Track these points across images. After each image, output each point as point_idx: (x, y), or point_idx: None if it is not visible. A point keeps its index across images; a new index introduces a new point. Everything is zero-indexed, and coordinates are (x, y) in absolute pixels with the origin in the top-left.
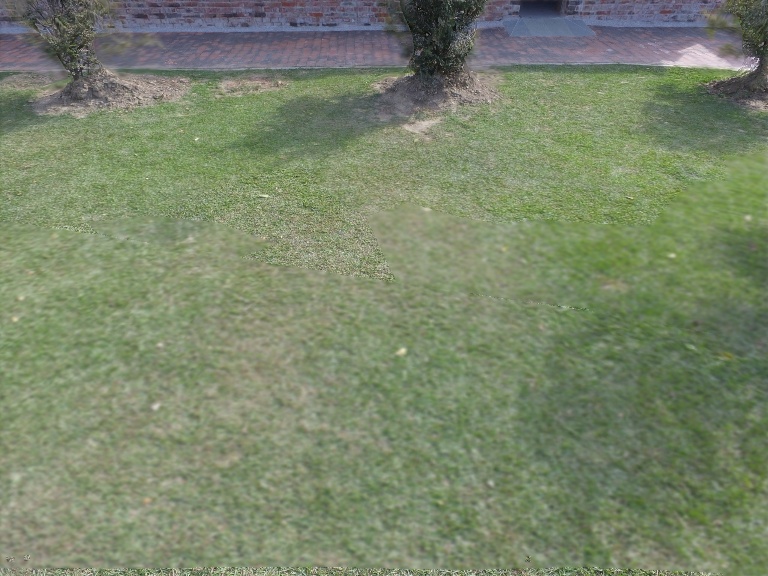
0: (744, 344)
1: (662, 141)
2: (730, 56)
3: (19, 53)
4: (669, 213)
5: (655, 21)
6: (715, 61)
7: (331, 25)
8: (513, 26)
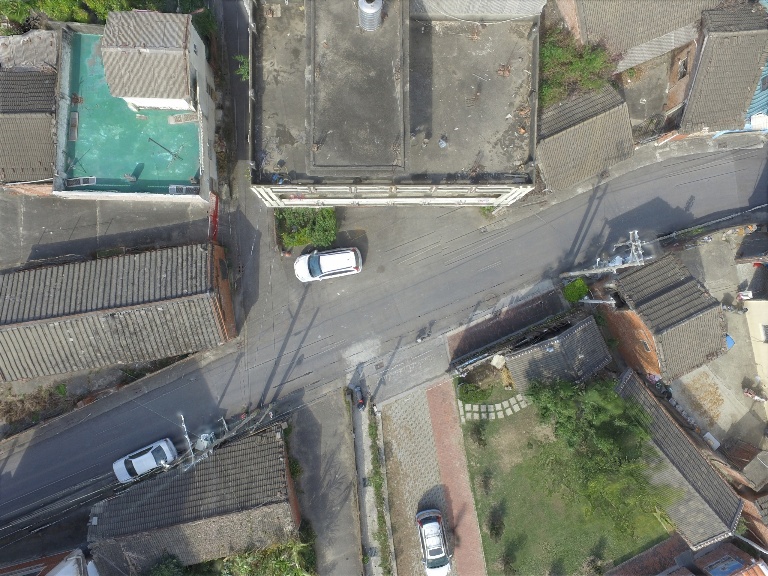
0: (516, 547)
1: None
2: None
3: (625, 575)
4: (520, 563)
5: None
6: None
7: None
8: None
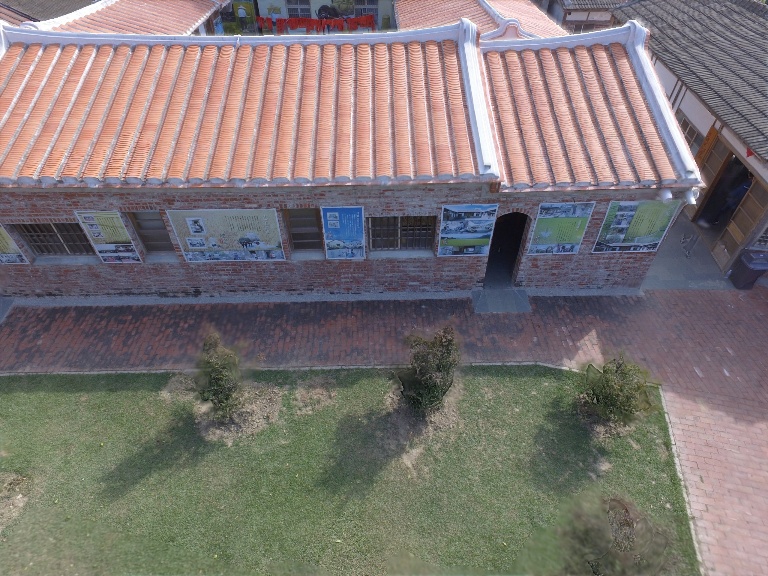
0: None
1: (535, 480)
2: (608, 351)
3: (165, 340)
4: (519, 559)
5: (575, 288)
6: (596, 361)
7: (357, 293)
8: (478, 300)
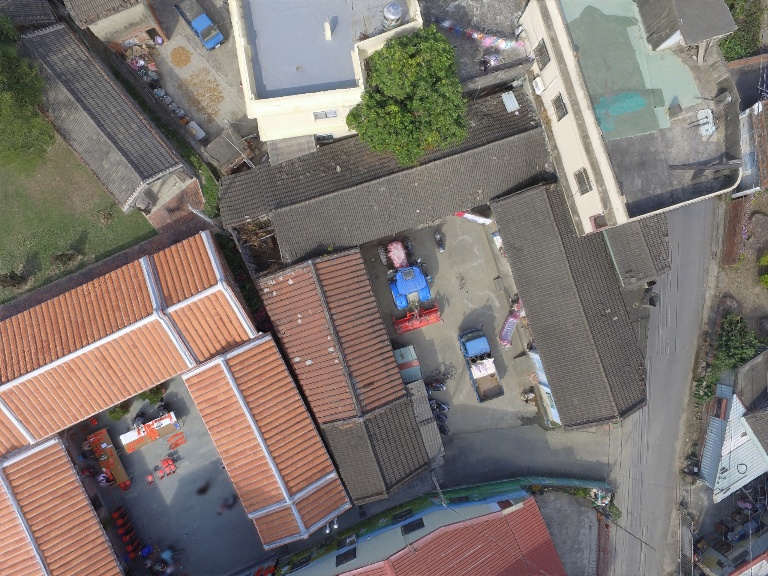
0: None
1: None
2: None
3: (107, 271)
4: None
5: None
6: None
7: None
8: None
